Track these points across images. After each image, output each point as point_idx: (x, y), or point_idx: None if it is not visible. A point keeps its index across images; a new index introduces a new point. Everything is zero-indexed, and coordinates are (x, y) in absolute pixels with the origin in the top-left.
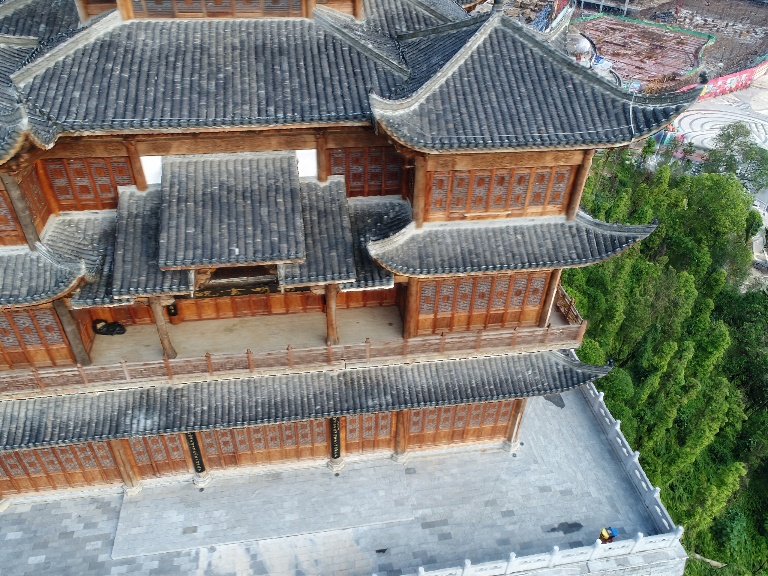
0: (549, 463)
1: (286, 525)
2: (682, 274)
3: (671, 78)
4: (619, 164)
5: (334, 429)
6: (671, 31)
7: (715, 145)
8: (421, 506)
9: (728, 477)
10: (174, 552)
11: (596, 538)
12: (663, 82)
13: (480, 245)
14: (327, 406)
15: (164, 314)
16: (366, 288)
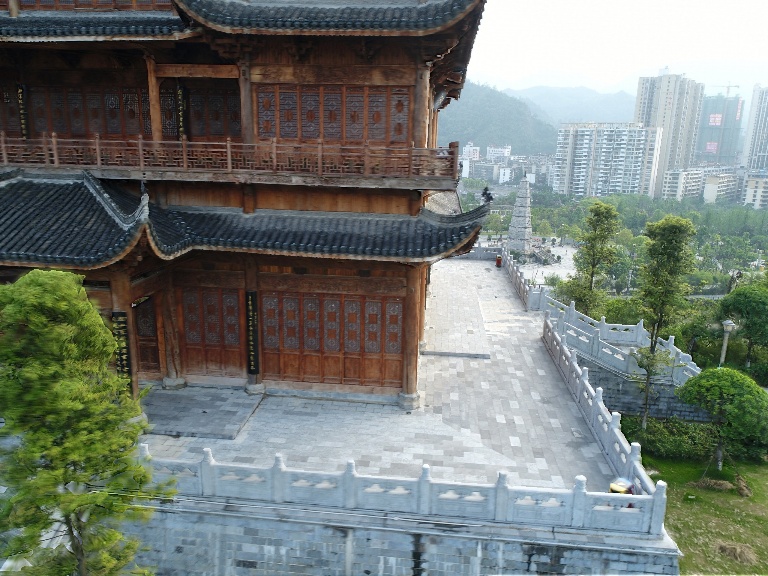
0: None
1: None
2: None
3: None
4: None
5: None
6: None
7: None
8: None
9: None
10: None
11: (496, 267)
12: None
13: None
14: None
15: None
16: None
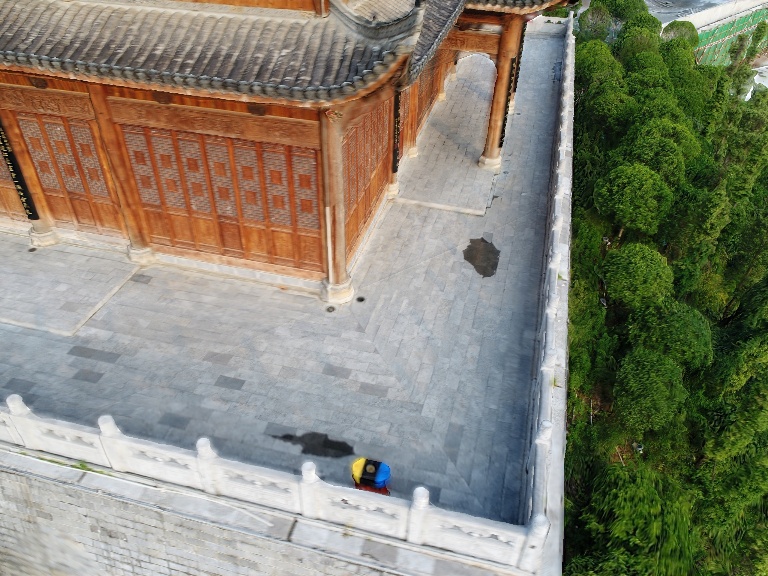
0: (383, 338)
1: None
2: None
3: None
4: None
5: (1, 146)
6: None
7: None
8: (103, 324)
9: None
10: None
11: None
12: None
13: None
14: None
15: None
16: None
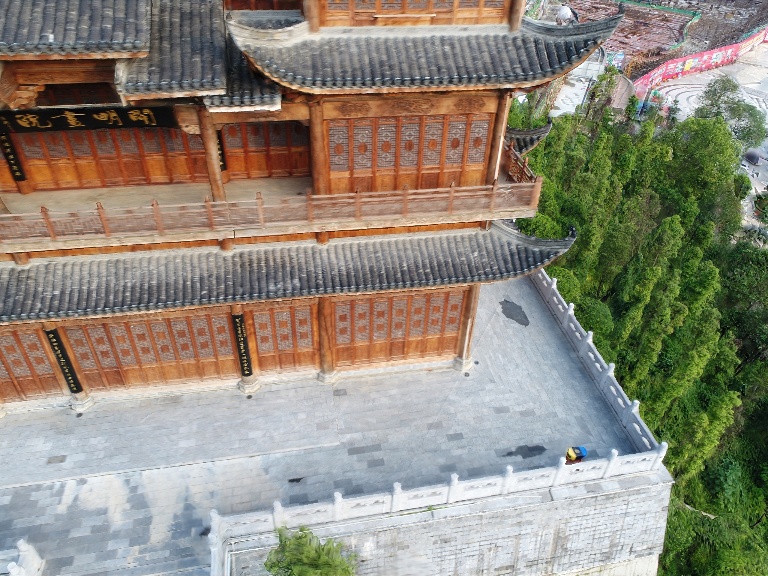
0: (508, 382)
1: (179, 452)
2: (667, 220)
3: (656, 53)
4: (602, 125)
5: (239, 335)
6: (655, 9)
7: (701, 103)
8: (349, 430)
9: (721, 409)
10: (33, 485)
11: None
12: (648, 57)
13: (396, 57)
14: (216, 291)
15: (9, 179)
16: (242, 107)
